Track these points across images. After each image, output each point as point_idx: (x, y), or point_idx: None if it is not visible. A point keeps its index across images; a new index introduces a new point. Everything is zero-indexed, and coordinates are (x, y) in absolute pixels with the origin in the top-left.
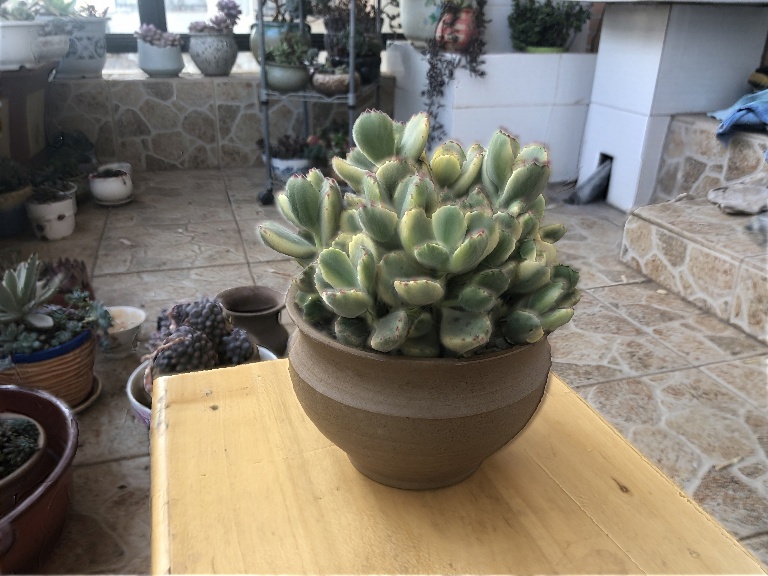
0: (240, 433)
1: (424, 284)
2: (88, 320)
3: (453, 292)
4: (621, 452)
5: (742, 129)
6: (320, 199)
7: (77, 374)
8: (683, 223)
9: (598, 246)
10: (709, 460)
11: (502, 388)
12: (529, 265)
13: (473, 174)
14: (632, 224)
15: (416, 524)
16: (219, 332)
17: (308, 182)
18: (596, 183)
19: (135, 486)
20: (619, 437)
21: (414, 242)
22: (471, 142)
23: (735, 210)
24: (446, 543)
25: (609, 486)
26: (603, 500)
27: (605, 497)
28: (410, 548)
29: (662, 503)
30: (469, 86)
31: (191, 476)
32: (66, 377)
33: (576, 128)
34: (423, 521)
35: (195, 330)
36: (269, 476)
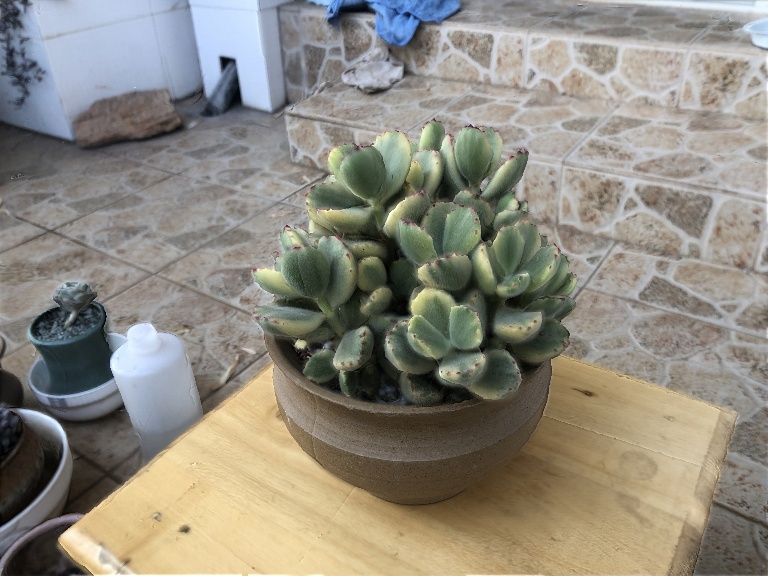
0: (247, 540)
1: (540, 320)
2: None
3: (510, 307)
4: (555, 362)
5: (349, 10)
6: (329, 261)
7: None
8: (341, 113)
9: (264, 153)
10: None
11: (543, 369)
12: None
13: (440, 174)
14: (295, 125)
15: (493, 522)
16: None
17: (311, 247)
18: (227, 89)
19: None
20: None
21: (495, 278)
22: (79, 75)
23: (374, 89)
24: (531, 522)
25: (577, 397)
26: (585, 411)
27: (584, 408)
28: (512, 546)
29: (617, 390)
30: (53, 9)
31: None
32: None
33: (186, 35)
34: (496, 515)
35: None
36: (328, 565)
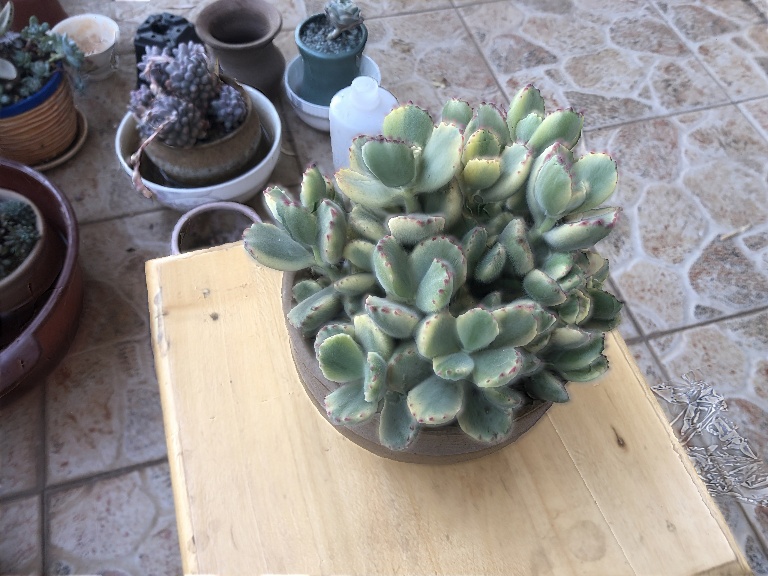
0: (244, 357)
1: (441, 420)
2: (55, 58)
3: None
4: (627, 388)
5: None
6: (317, 228)
7: (58, 121)
8: None
9: None
10: (716, 227)
11: None
12: (567, 335)
13: (516, 185)
14: None
15: (418, 485)
16: (207, 96)
17: (301, 209)
18: None
19: (144, 249)
20: (628, 364)
21: (433, 352)
22: None
23: None
24: (445, 510)
25: (607, 437)
26: (598, 456)
27: (601, 453)
28: (411, 516)
29: (654, 460)
30: None
31: (200, 419)
32: (47, 127)
33: None
34: (425, 482)
35: (179, 99)
36: (277, 420)
